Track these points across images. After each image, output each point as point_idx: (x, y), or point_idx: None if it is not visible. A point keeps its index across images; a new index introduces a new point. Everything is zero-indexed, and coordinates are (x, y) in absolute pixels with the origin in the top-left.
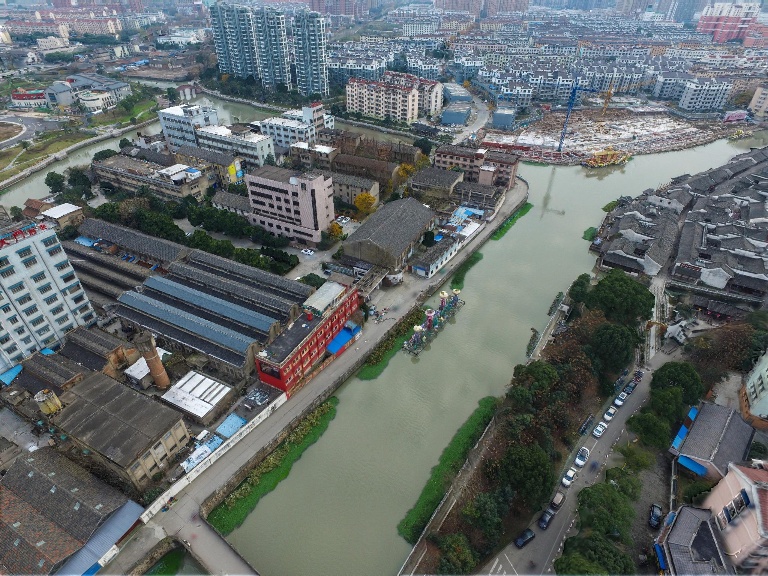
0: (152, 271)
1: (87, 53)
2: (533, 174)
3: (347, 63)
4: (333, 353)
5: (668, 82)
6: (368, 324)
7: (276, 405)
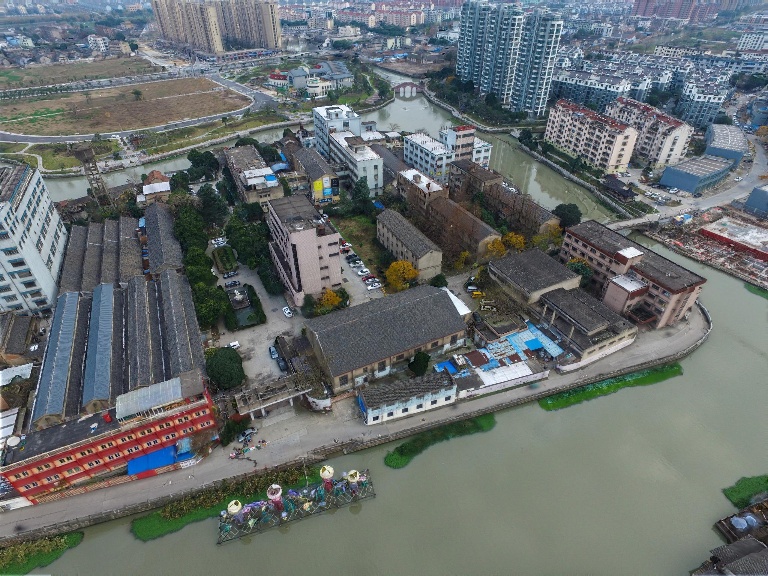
0: (139, 274)
1: (363, 43)
2: (746, 313)
3: (587, 79)
4: (128, 473)
5: None
6: (222, 452)
7: (12, 505)
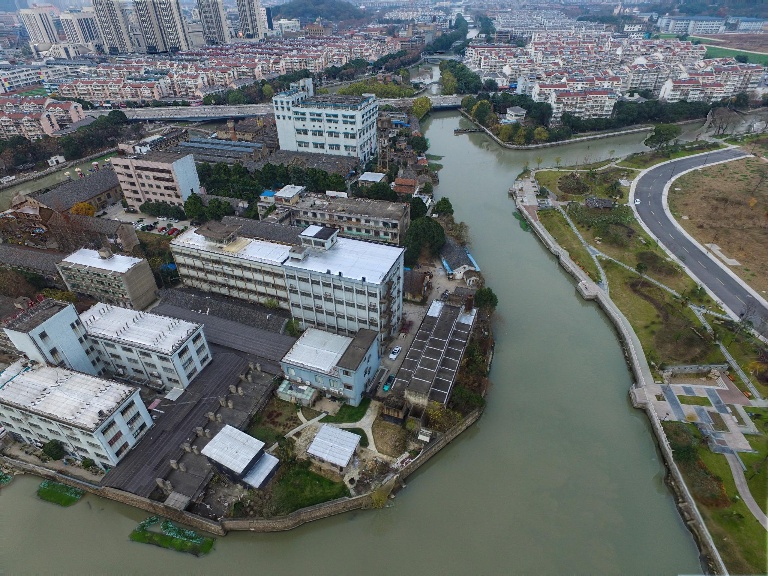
0: None
1: None
2: None
3: None
4: None
5: None
6: None
7: None
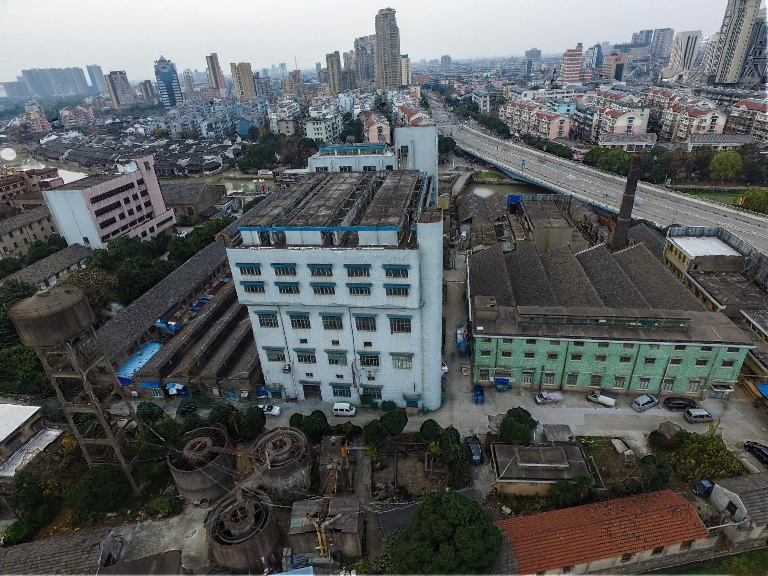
0: None
1: None
2: None
3: None
4: None
5: None
6: None
7: None
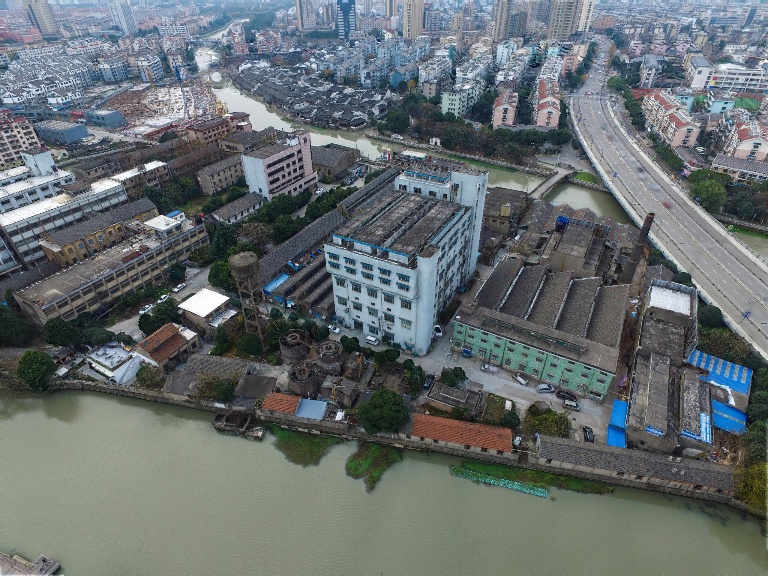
0: None
1: None
2: None
3: None
4: None
5: (112, 67)
6: None
7: None
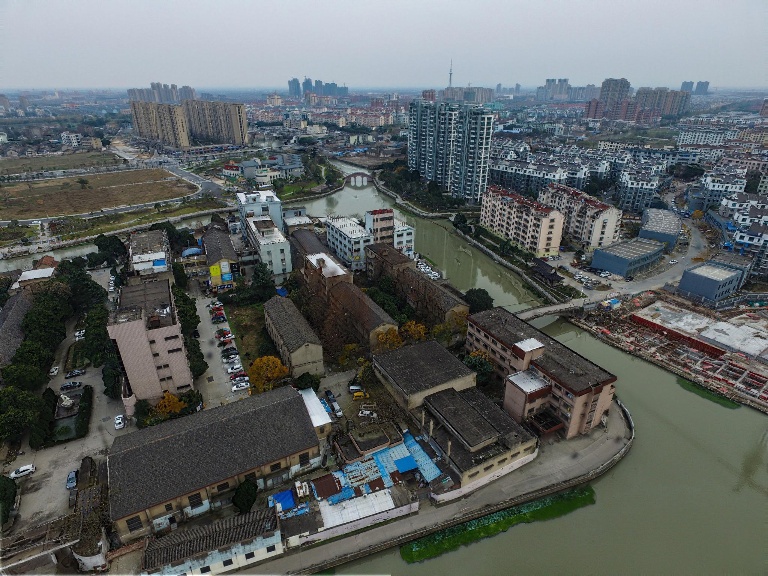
0: None
1: (327, 139)
2: (677, 416)
3: (525, 168)
4: None
5: None
6: None
7: None
